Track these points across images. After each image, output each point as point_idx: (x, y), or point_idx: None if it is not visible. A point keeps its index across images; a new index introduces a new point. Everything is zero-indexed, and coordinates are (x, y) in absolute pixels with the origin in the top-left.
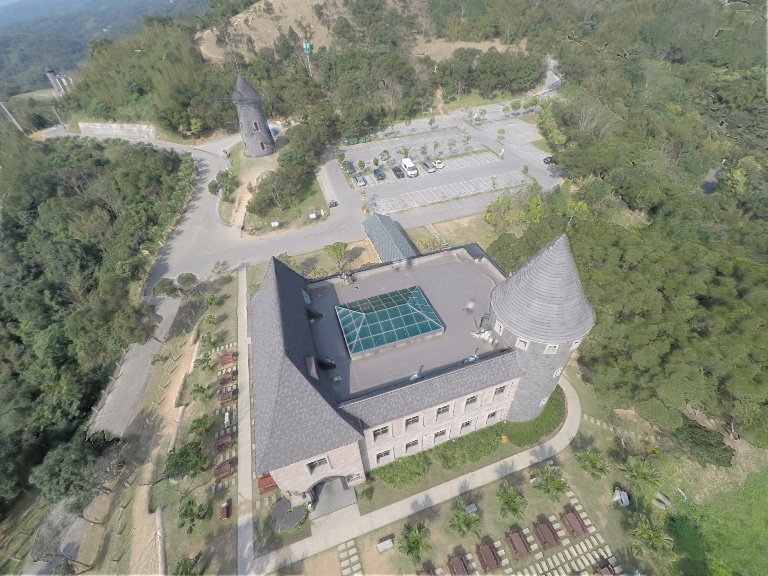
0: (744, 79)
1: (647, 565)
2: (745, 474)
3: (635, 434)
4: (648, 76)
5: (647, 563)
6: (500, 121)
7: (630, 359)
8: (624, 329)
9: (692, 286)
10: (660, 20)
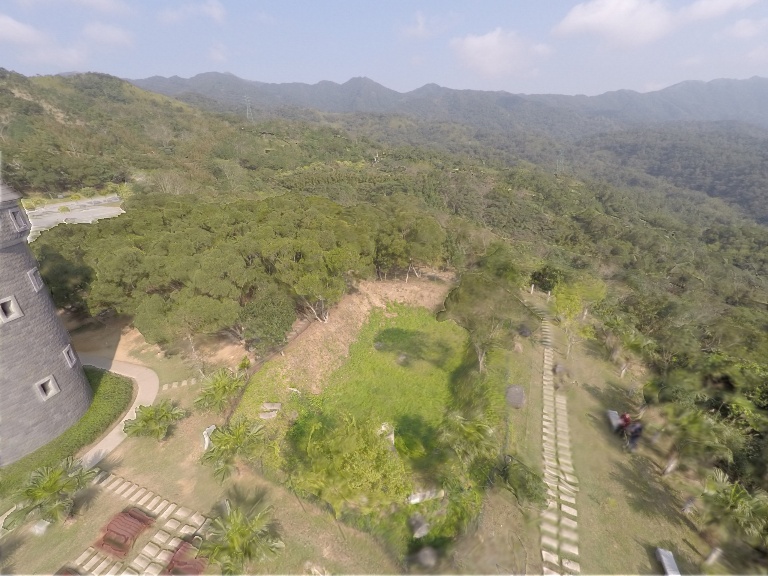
0: (295, 174)
1: (258, 488)
2: (347, 346)
3: (232, 368)
4: (224, 170)
5: (257, 486)
6: (72, 210)
7: (181, 287)
8: (160, 260)
9: (229, 215)
10: (223, 144)
